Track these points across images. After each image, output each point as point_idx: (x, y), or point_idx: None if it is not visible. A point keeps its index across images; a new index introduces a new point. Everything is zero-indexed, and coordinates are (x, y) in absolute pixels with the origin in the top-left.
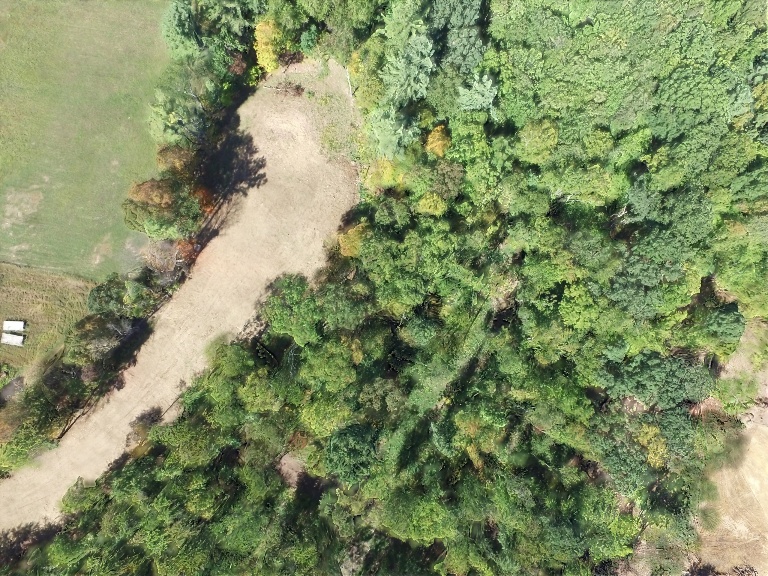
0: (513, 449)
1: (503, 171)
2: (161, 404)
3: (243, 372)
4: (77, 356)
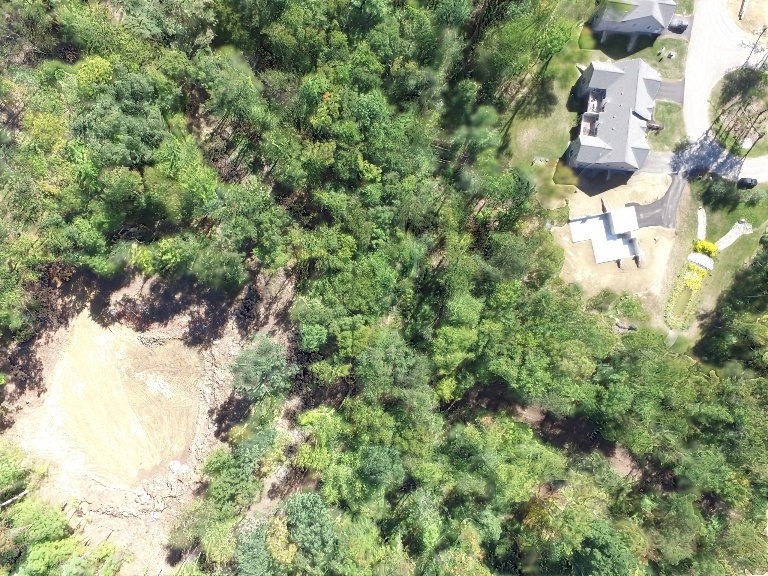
0: None
1: None
2: None
3: None
4: None
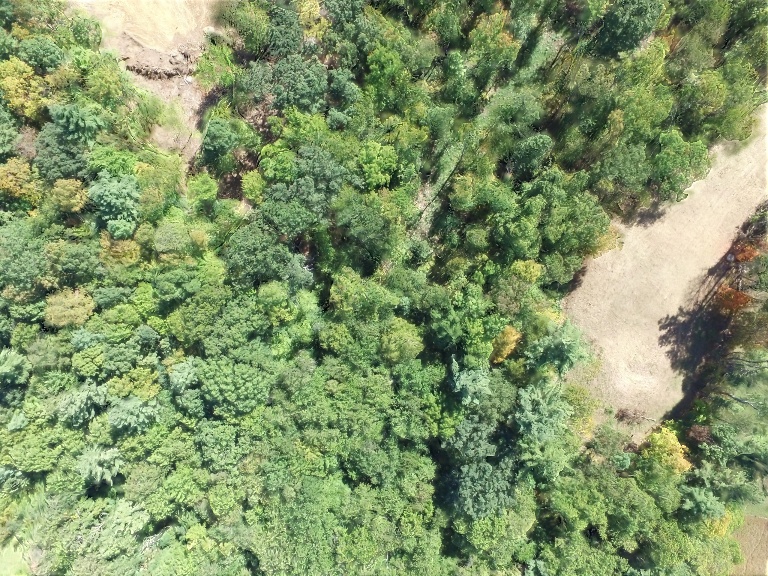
0: None
1: (441, 310)
2: None
3: (718, 116)
4: None
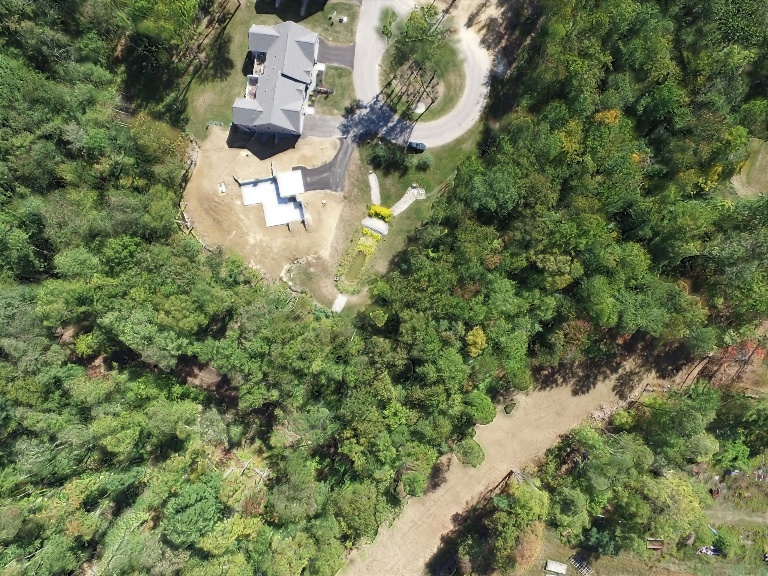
0: (78, 426)
1: None
2: None
3: (312, 569)
4: None
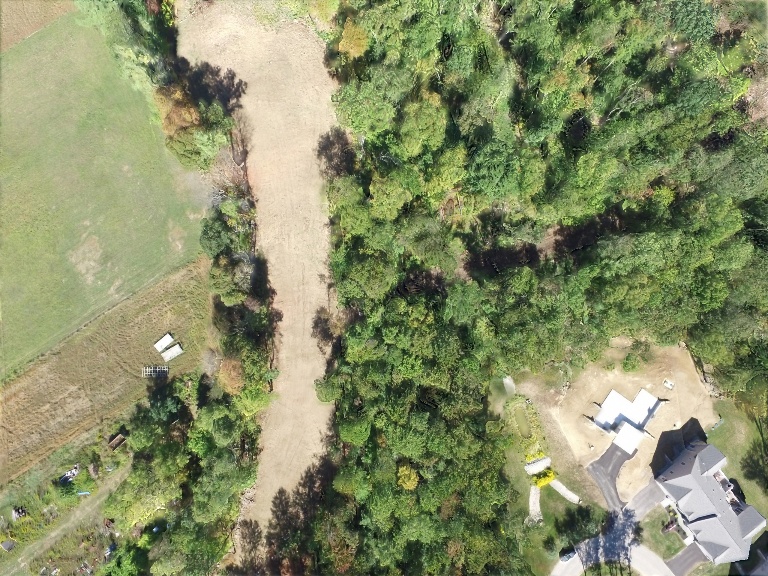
0: (598, 118)
1: None
2: (321, 304)
3: (361, 199)
4: (233, 294)
